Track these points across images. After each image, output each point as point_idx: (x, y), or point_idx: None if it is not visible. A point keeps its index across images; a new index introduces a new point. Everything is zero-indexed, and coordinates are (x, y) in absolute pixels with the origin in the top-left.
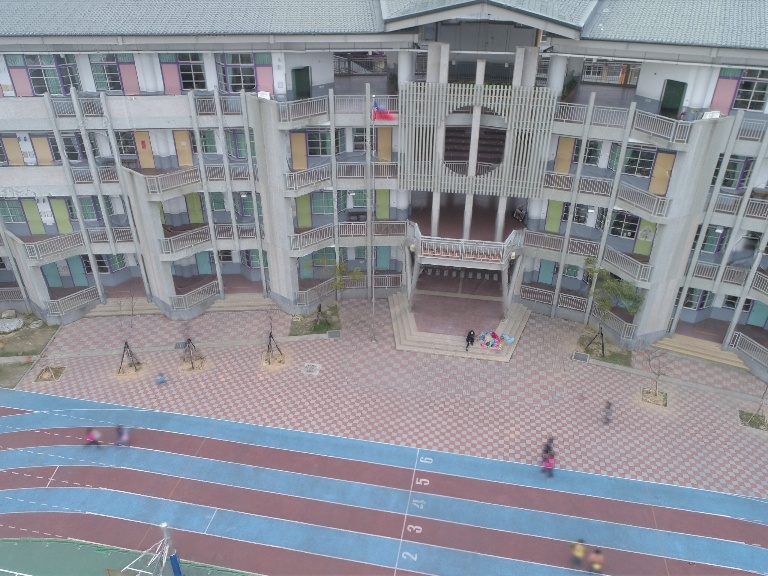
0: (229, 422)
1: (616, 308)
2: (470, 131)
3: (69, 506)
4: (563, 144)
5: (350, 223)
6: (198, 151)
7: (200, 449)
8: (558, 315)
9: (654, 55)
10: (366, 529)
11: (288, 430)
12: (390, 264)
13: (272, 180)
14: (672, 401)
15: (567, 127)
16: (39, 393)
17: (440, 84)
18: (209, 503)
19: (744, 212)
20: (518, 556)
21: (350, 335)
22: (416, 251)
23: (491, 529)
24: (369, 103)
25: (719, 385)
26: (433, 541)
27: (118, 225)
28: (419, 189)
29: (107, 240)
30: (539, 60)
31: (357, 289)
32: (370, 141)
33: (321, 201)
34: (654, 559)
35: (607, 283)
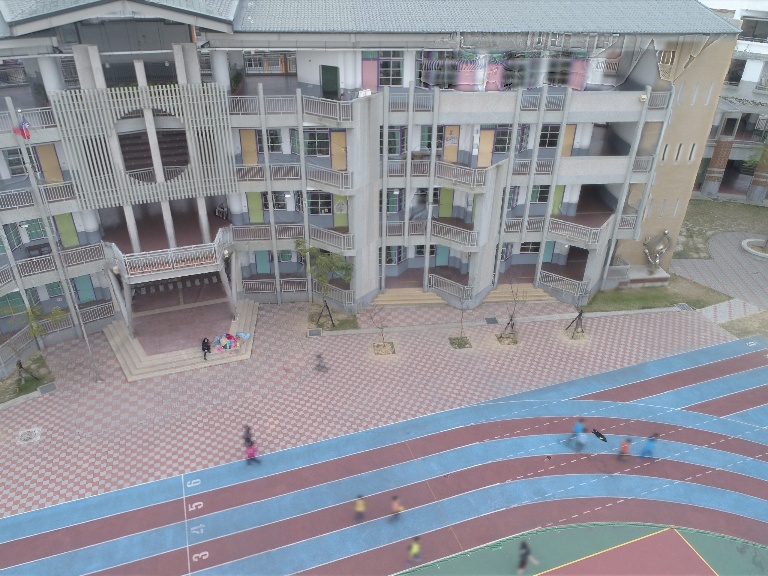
0: None
1: (333, 280)
2: (146, 136)
3: None
4: (245, 136)
5: (31, 259)
6: None
7: None
8: (284, 300)
9: (304, 44)
10: None
11: (18, 515)
12: (95, 294)
13: None
14: (398, 347)
15: (244, 119)
16: None
17: (98, 90)
18: None
19: (410, 173)
20: (308, 535)
21: (68, 383)
22: (121, 272)
23: (277, 522)
24: (16, 119)
25: (429, 322)
26: (223, 559)
27: None
28: (106, 206)
29: None
30: (199, 56)
31: (62, 331)
32: (30, 162)
33: None
34: (419, 485)
35: (319, 259)
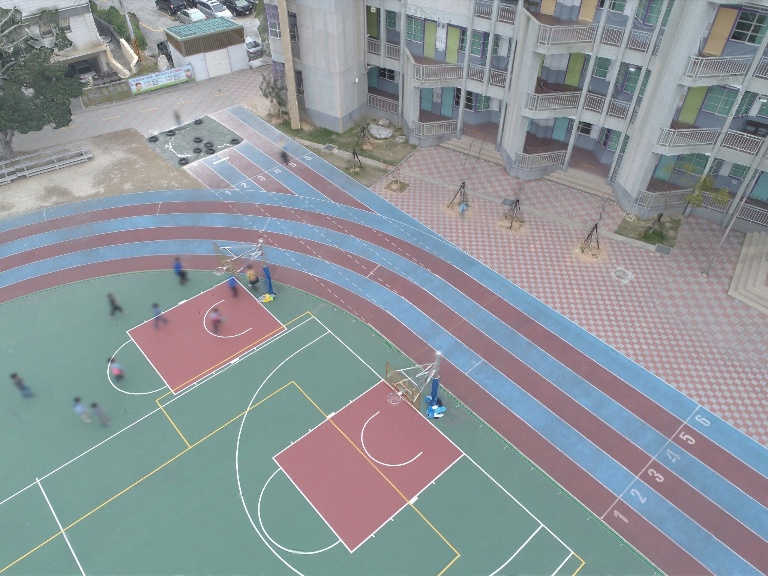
0: (523, 291)
1: None
2: None
3: (377, 300)
4: None
5: (743, 134)
6: (604, 8)
7: (489, 303)
8: None
9: None
10: (607, 448)
11: (573, 323)
12: None
13: (672, 60)
14: None
15: None
16: (385, 199)
17: None
18: (479, 352)
19: None
20: (758, 565)
21: (680, 257)
22: None
23: (741, 523)
24: None
25: None
26: (670, 497)
27: (497, 67)
28: None
29: (482, 80)
30: None
31: (713, 211)
32: None
33: (719, 98)
34: None
35: None
